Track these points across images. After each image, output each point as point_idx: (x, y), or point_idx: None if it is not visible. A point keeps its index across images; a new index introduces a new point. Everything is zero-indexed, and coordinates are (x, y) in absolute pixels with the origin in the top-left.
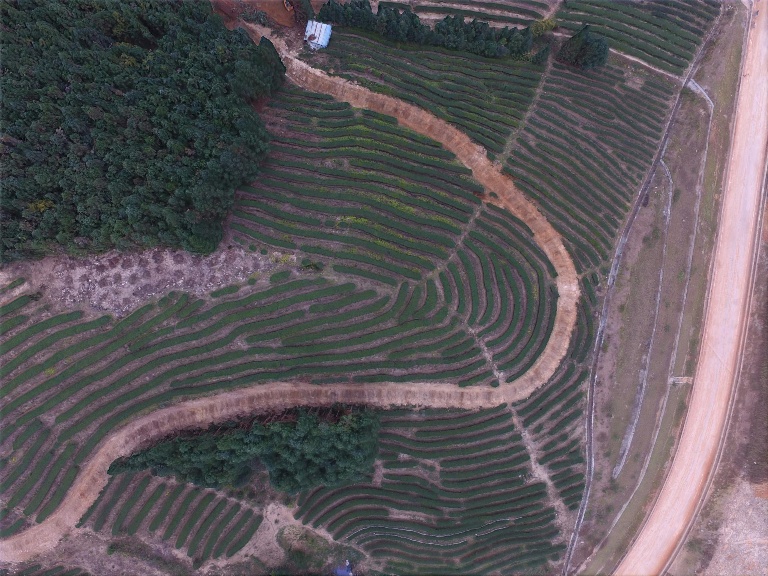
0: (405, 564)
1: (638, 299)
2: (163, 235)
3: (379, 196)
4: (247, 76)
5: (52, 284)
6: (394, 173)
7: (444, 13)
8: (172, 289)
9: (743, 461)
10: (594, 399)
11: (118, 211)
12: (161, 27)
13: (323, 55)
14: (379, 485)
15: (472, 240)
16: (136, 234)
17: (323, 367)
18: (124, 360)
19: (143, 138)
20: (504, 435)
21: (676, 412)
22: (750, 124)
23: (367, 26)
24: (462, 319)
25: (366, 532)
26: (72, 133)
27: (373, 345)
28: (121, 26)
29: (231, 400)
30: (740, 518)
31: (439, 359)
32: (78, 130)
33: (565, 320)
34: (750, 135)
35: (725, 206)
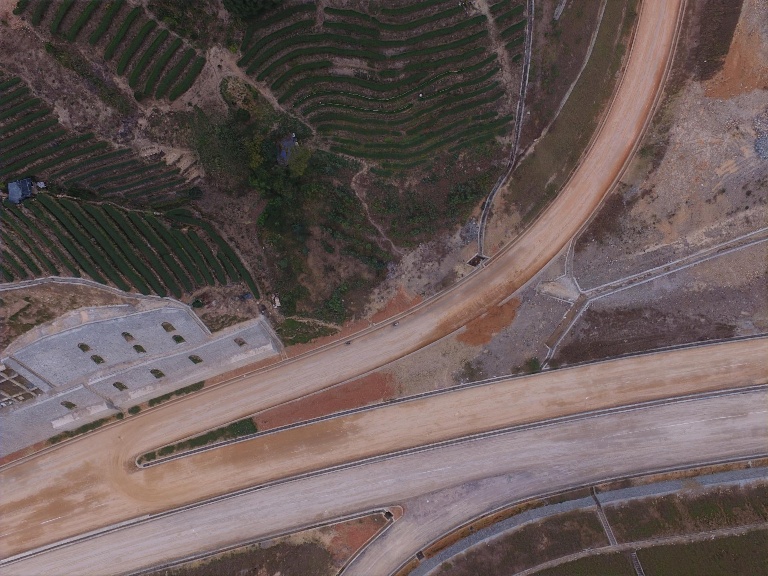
0: (352, 140)
1: None
2: None
3: None
4: None
5: None
6: None
7: None
8: None
9: (694, 63)
10: None
11: None
12: None
13: None
14: (322, 31)
15: None
16: None
17: None
18: None
19: None
20: None
21: (626, 18)
22: None
23: None
24: None
25: (311, 98)
26: None
27: None
28: None
29: None
30: (691, 118)
31: None
32: None
33: None
34: None
35: None
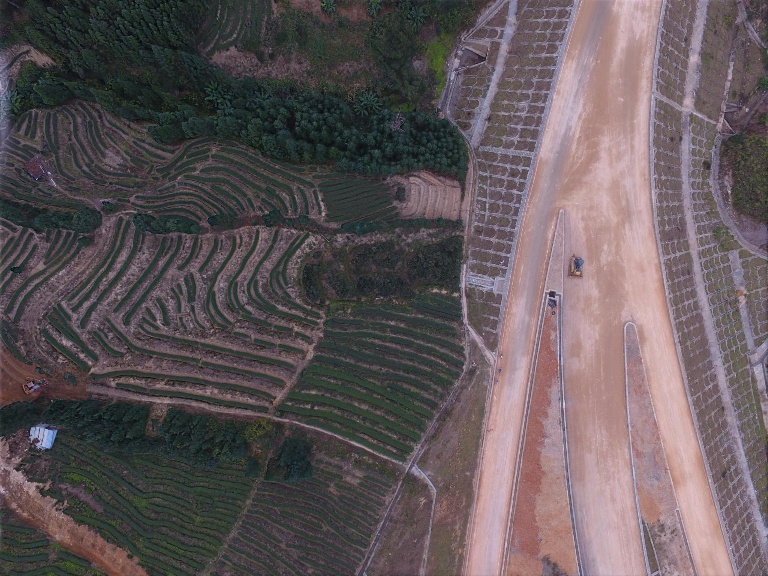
0: None
1: None
2: None
3: None
4: None
5: None
6: None
7: (177, 396)
8: None
9: None
10: None
11: None
12: None
13: (48, 456)
14: None
15: None
16: None
17: None
18: None
19: None
20: None
21: None
22: (494, 478)
23: None
24: None
25: None
26: None
27: None
28: None
29: None
30: None
31: None
32: None
33: None
34: (494, 489)
35: (470, 558)
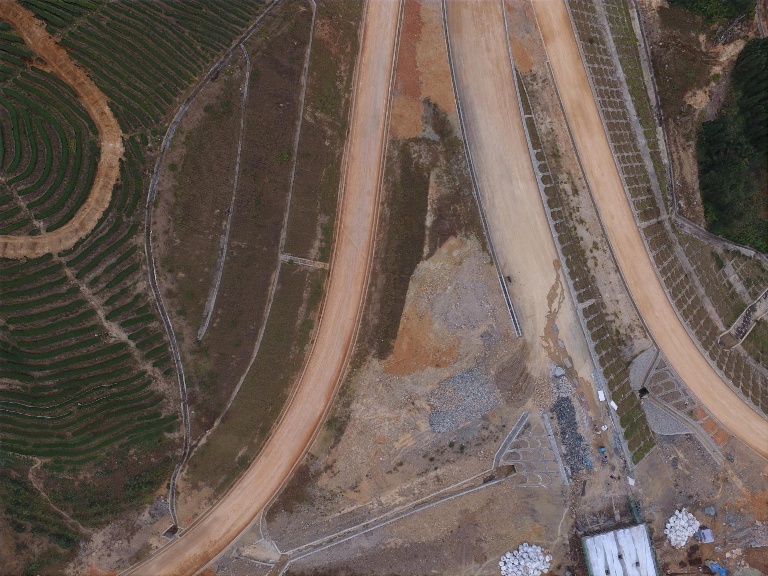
0: (20, 441)
1: (204, 164)
2: None
3: None
4: None
5: None
6: None
7: None
8: None
9: (374, 340)
10: (152, 254)
11: None
12: None
13: None
14: None
15: (7, 97)
16: None
17: None
18: None
19: None
20: (63, 289)
21: (312, 296)
22: (378, 31)
23: None
24: None
25: None
26: None
27: None
28: None
29: None
30: (370, 394)
31: None
32: None
33: (109, 175)
34: (379, 41)
35: (357, 105)
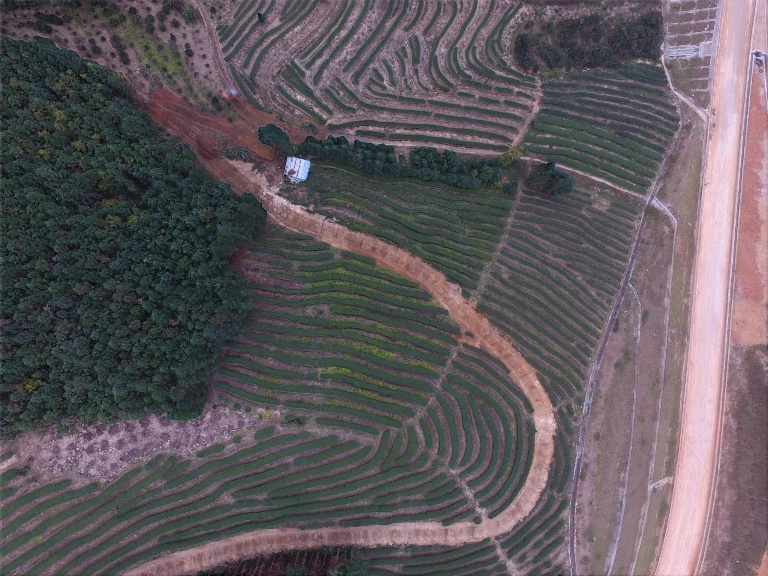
0: None
1: (613, 423)
2: (149, 410)
3: (359, 343)
4: (228, 237)
5: (40, 455)
6: (373, 318)
7: (418, 140)
8: (159, 451)
9: (726, 559)
10: (575, 525)
11: (104, 389)
12: (145, 179)
13: (303, 188)
14: None
15: (450, 382)
16: (122, 413)
17: (309, 515)
18: (112, 523)
19: (128, 309)
20: (489, 565)
21: (659, 513)
22: (713, 230)
23: (344, 161)
24: (443, 462)
25: None
26: (59, 310)
27: (357, 491)
28: (106, 181)
29: (219, 548)
30: None
31: (422, 501)
32: (65, 307)
33: (543, 453)
34: (714, 240)
35: (694, 309)
